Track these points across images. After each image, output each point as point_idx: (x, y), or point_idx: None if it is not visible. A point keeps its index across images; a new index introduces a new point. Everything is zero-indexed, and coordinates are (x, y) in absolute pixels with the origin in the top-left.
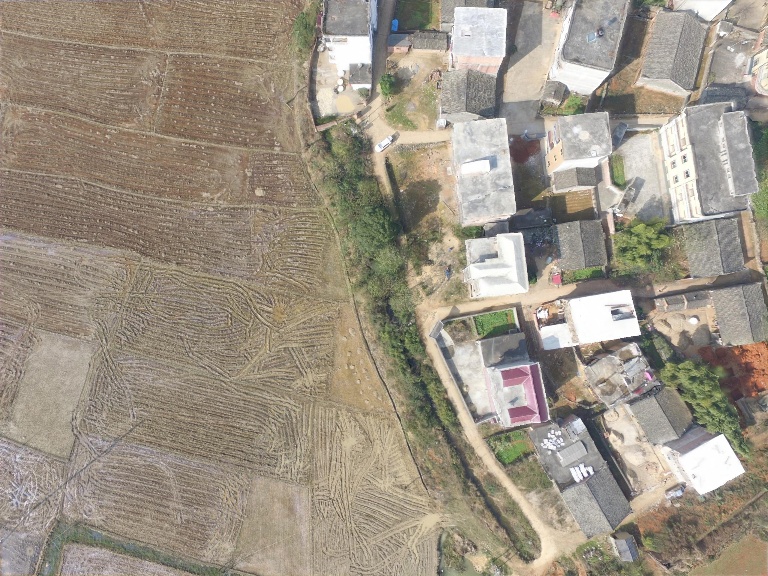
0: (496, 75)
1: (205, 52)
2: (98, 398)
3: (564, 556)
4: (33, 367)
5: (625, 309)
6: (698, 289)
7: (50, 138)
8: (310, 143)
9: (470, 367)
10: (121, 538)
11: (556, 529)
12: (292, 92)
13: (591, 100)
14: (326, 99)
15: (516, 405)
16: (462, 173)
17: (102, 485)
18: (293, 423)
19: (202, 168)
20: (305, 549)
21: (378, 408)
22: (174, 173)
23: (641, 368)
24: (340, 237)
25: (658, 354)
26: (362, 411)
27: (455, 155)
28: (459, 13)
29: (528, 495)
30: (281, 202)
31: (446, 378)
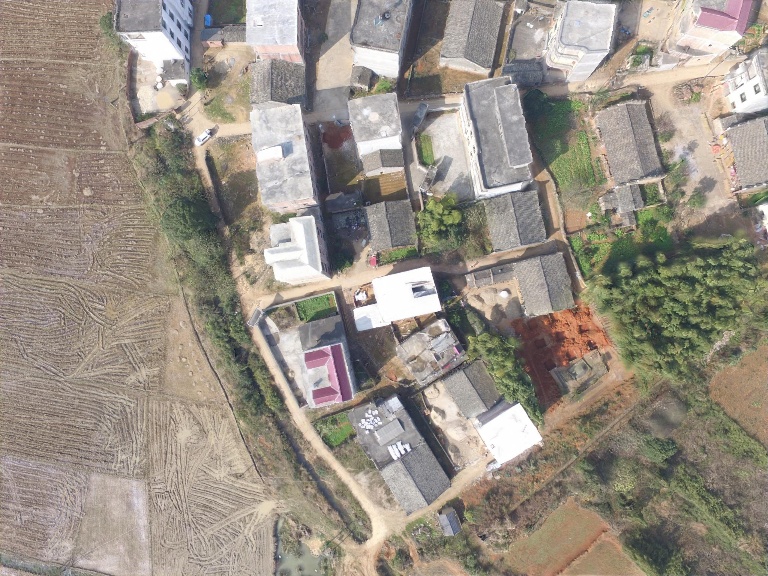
0: (303, 63)
1: (29, 57)
2: None
3: (394, 535)
4: None
5: (429, 286)
6: (506, 262)
7: None
8: (133, 141)
9: (295, 353)
10: None
11: (385, 508)
12: (116, 92)
13: (400, 83)
14: (147, 96)
15: (321, 386)
16: (258, 160)
17: None
18: (128, 418)
19: (30, 171)
20: (144, 543)
21: (211, 399)
22: (3, 178)
23: (449, 343)
24: None
25: (472, 329)
26: (195, 403)
27: (252, 143)
28: (251, 4)
29: (357, 476)
30: (109, 200)
31: (273, 365)
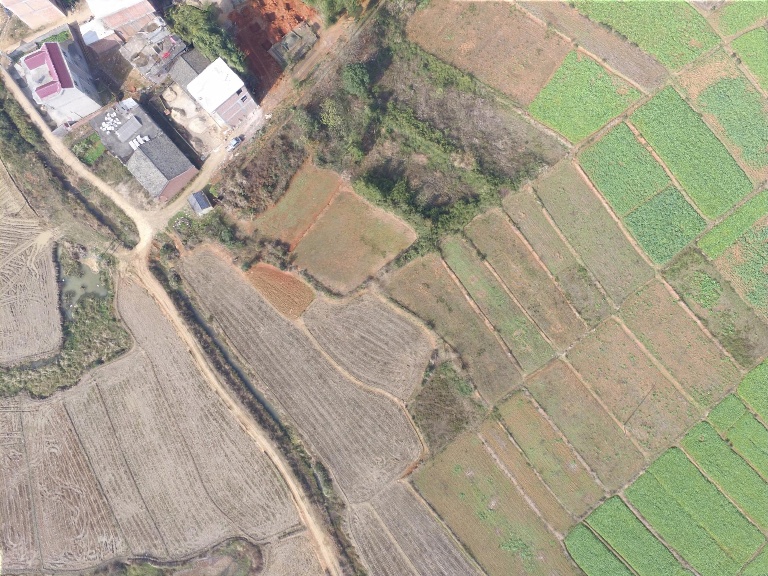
0: None
1: None
2: None
3: (159, 232)
4: None
5: None
6: None
7: None
8: None
9: None
10: None
11: (147, 210)
12: None
13: None
14: None
15: (44, 83)
16: None
17: None
18: None
19: None
20: None
21: None
22: None
23: (165, 35)
24: None
25: None
26: None
27: None
28: None
29: (117, 187)
30: None
31: (27, 105)
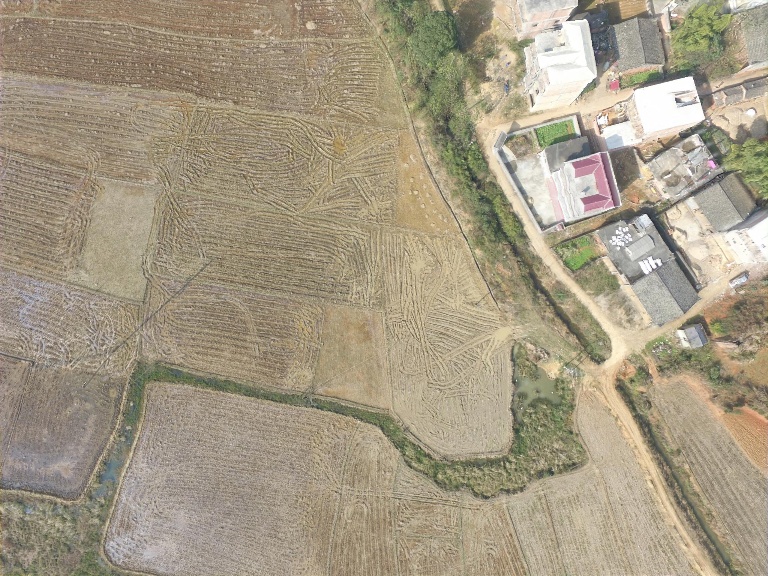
0: None
1: None
2: (166, 241)
3: (634, 353)
4: (98, 215)
5: (687, 98)
6: (755, 79)
7: None
8: None
9: (533, 180)
10: (202, 373)
11: (625, 328)
12: None
13: None
14: None
15: (588, 194)
16: None
17: (178, 324)
18: (362, 251)
19: (251, 5)
20: (382, 370)
21: (444, 230)
22: (223, 12)
23: (704, 157)
24: (396, 63)
25: (718, 149)
26: (429, 234)
27: None
28: None
29: (596, 298)
30: (333, 34)
31: (510, 193)
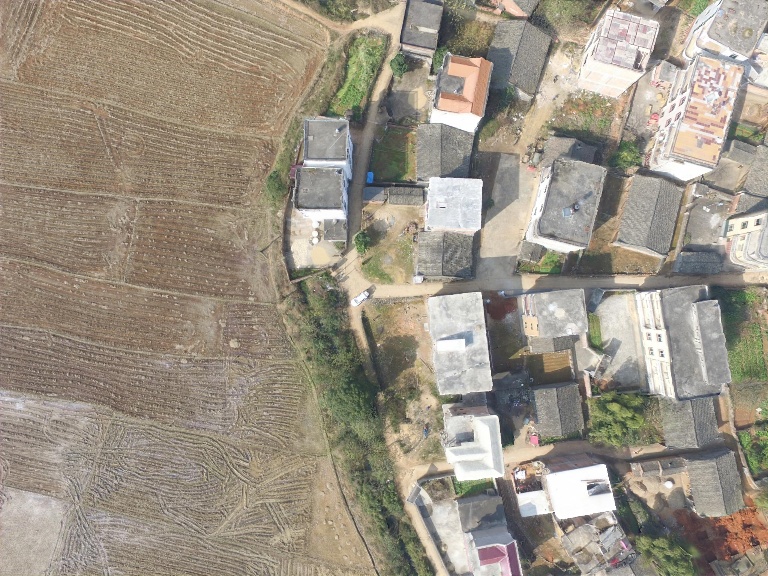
0: (473, 234)
1: (176, 198)
2: (71, 557)
3: None
4: (3, 526)
5: None
6: (673, 454)
7: (16, 288)
8: (285, 295)
9: (448, 526)
10: None
11: None
12: (266, 240)
13: (568, 257)
14: (301, 250)
15: None
16: (438, 350)
17: None
18: None
19: (175, 319)
20: None
21: (357, 564)
22: (146, 324)
23: (617, 537)
24: (317, 392)
25: (634, 516)
26: (341, 567)
27: (431, 330)
28: (434, 184)
29: None
30: (256, 354)
31: (424, 536)
